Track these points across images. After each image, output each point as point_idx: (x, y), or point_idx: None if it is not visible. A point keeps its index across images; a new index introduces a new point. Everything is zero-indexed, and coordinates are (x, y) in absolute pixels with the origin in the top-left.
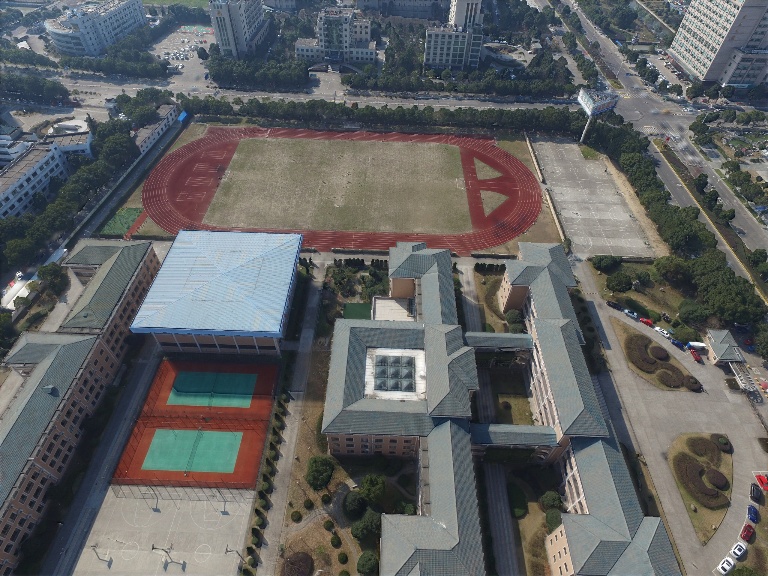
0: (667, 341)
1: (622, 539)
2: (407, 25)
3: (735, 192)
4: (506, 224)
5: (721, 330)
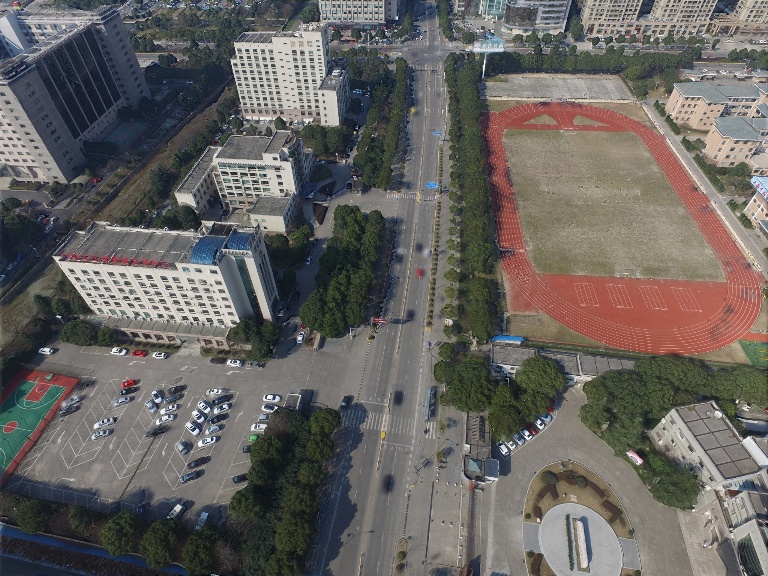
0: None
1: None
2: (205, 131)
3: (533, 47)
4: (615, 119)
5: (682, 70)
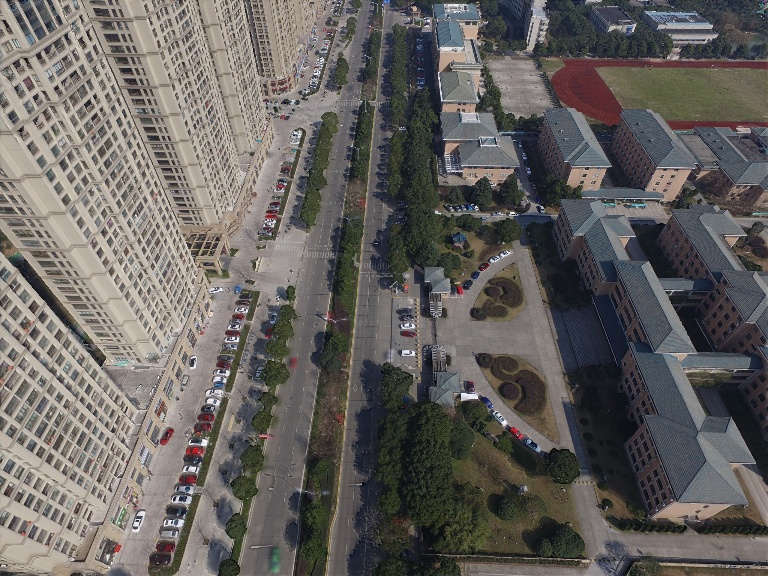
0: (496, 408)
1: (605, 219)
2: None
3: None
4: None
5: None
